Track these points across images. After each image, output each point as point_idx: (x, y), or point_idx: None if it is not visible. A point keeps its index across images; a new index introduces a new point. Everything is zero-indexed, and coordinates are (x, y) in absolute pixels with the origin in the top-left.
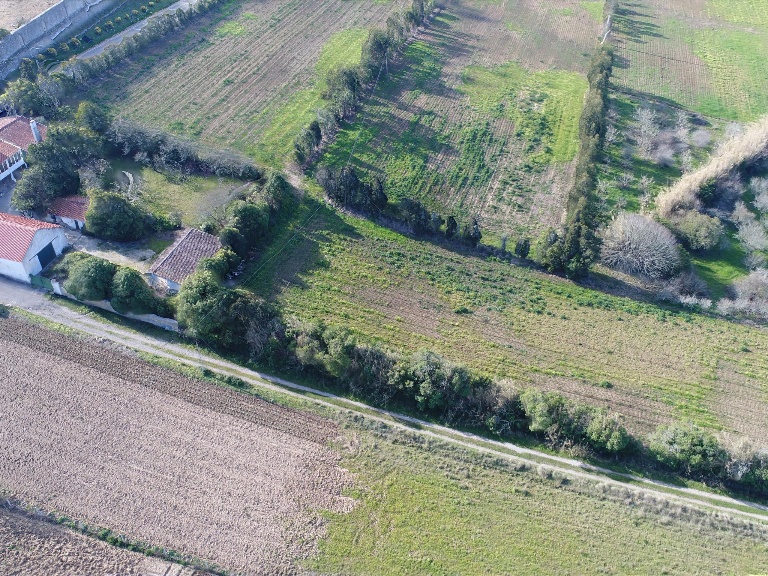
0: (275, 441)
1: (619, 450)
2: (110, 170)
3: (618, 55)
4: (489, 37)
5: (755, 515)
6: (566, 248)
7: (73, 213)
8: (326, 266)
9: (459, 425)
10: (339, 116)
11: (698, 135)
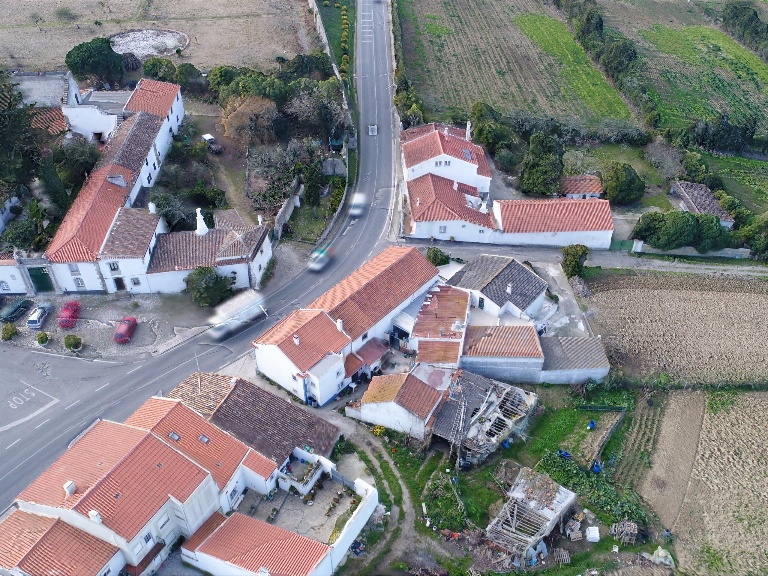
0: None
1: None
2: None
3: (711, 8)
4: (612, 8)
5: None
6: None
7: (581, 189)
8: (763, 193)
9: None
10: None
11: None
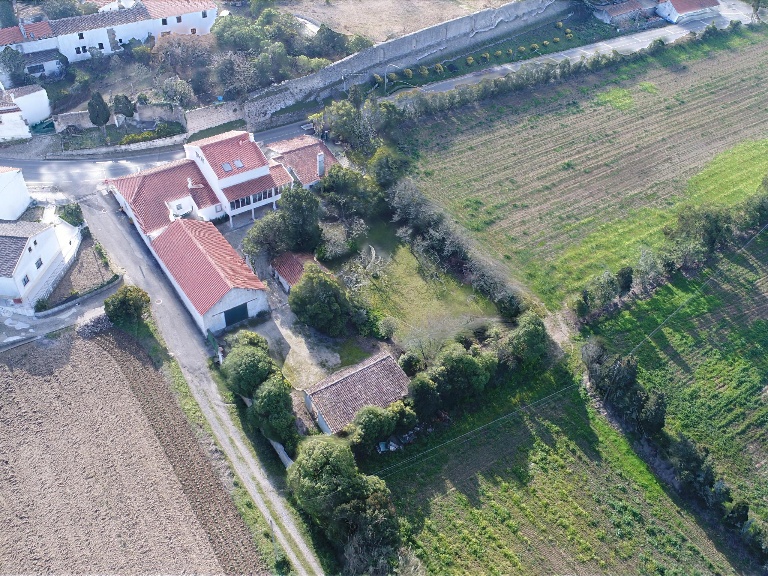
0: None
1: None
2: (364, 236)
3: None
4: None
5: None
6: None
7: (291, 276)
8: (523, 481)
9: None
10: (674, 265)
11: None
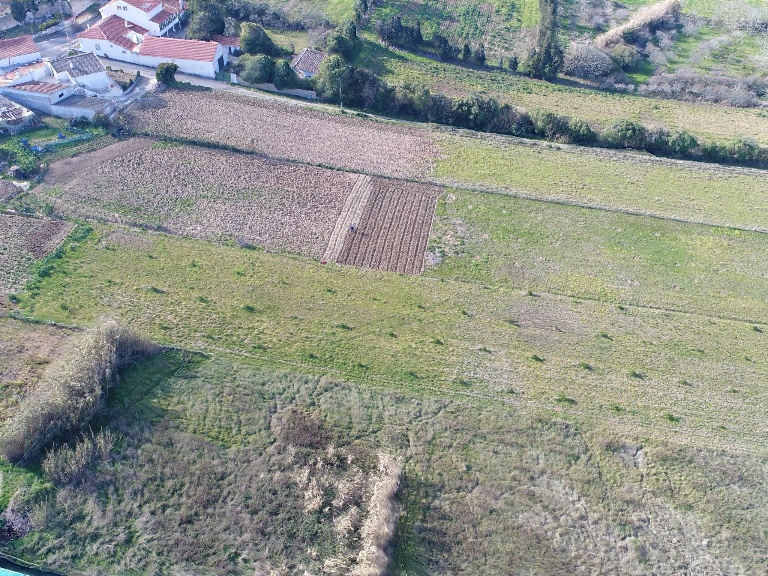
0: (395, 136)
1: (587, 138)
2: None
3: None
4: None
5: (663, 158)
6: (542, 58)
7: (228, 42)
8: (393, 72)
9: (495, 131)
10: None
11: (620, 12)
